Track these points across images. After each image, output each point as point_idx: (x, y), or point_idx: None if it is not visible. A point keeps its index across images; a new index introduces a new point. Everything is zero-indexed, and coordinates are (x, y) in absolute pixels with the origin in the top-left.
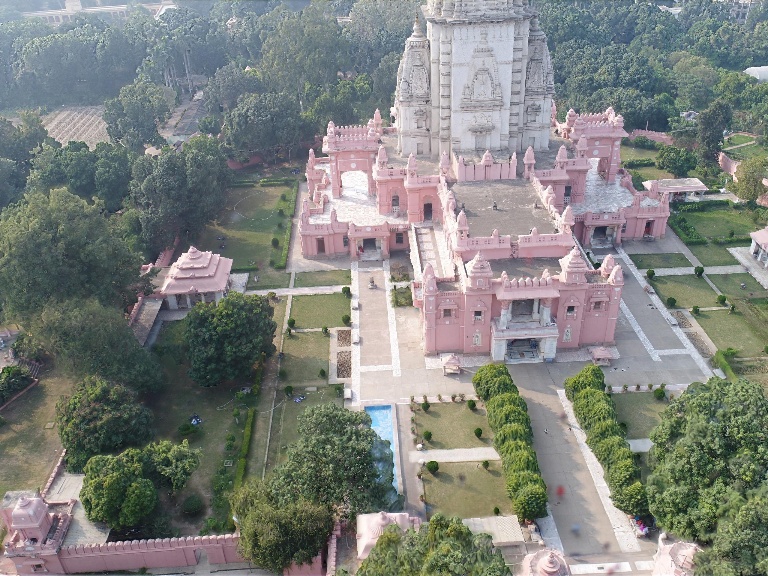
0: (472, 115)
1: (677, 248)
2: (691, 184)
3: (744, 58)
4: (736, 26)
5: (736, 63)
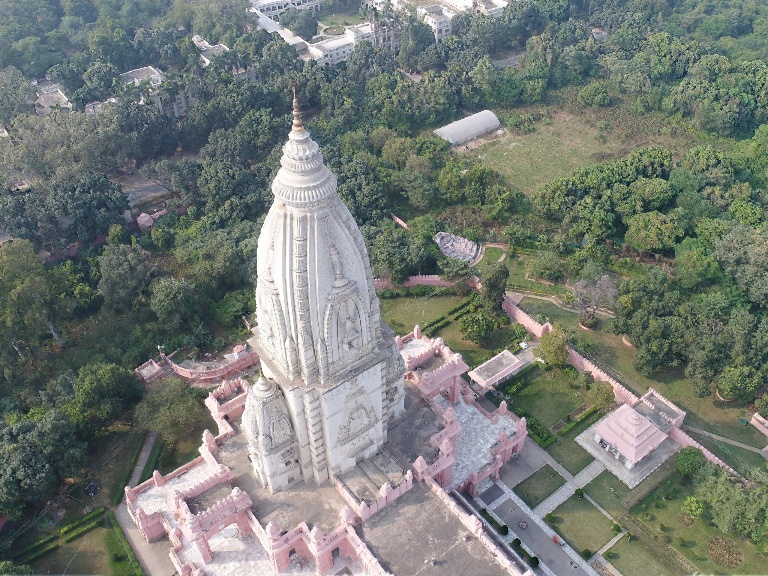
0: (350, 444)
1: (541, 458)
2: (509, 364)
3: (427, 115)
4: (410, 82)
5: (421, 120)
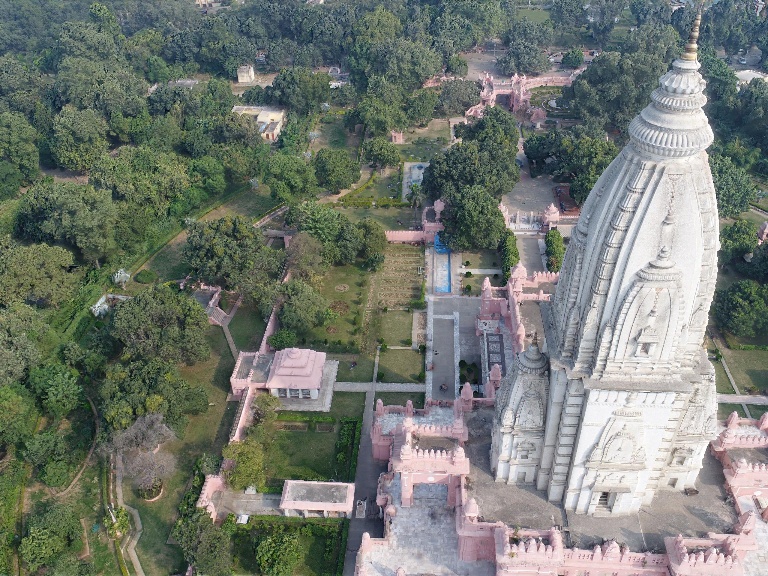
0: None
1: None
2: (303, 486)
3: None
4: None
5: None
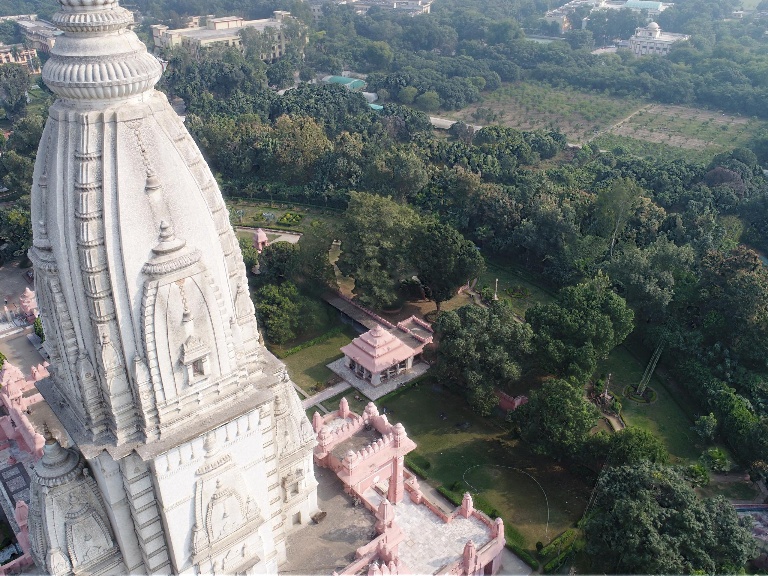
0: None
1: None
2: None
3: None
4: None
5: None
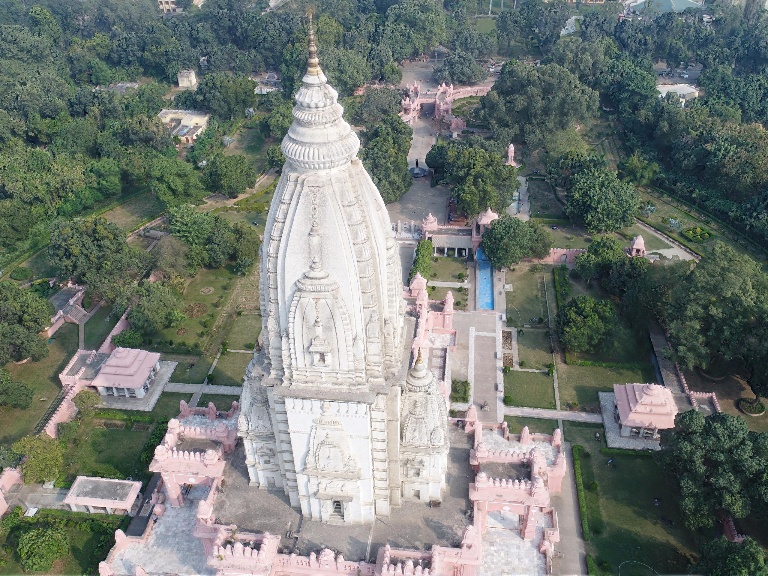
0: None
1: None
2: (91, 482)
3: None
4: None
5: None
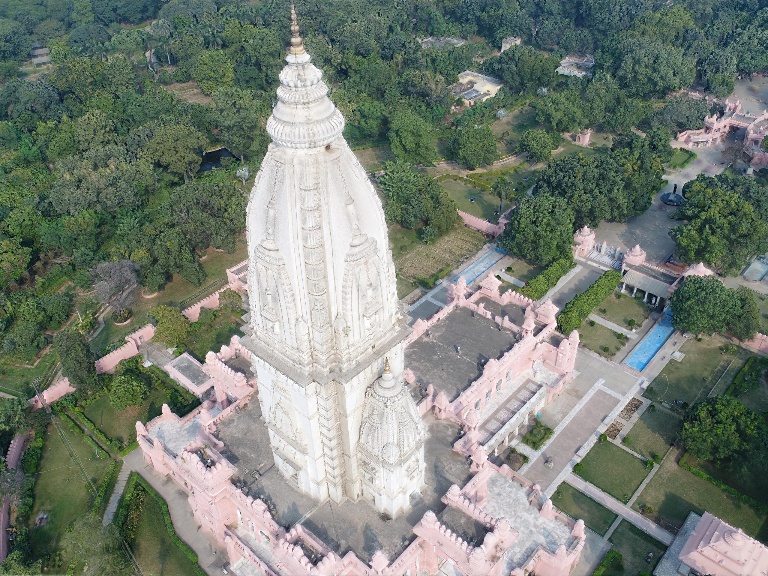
0: None
1: None
2: (188, 361)
3: None
4: None
5: None
